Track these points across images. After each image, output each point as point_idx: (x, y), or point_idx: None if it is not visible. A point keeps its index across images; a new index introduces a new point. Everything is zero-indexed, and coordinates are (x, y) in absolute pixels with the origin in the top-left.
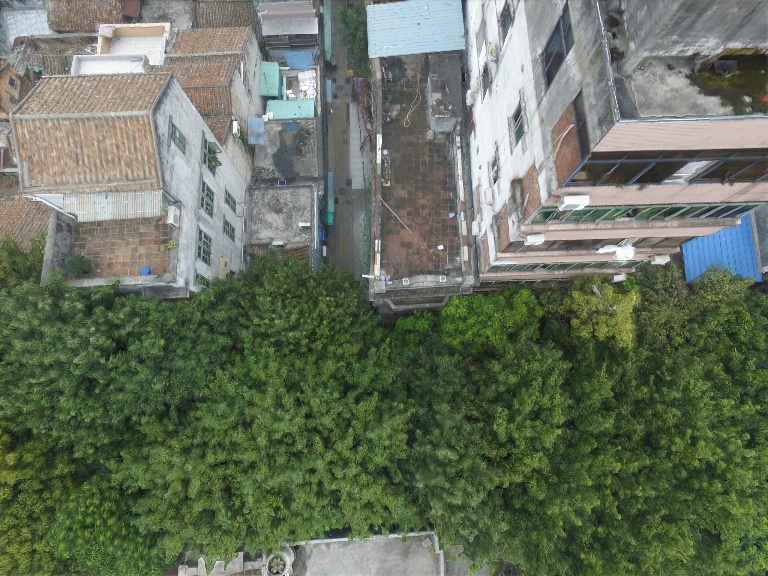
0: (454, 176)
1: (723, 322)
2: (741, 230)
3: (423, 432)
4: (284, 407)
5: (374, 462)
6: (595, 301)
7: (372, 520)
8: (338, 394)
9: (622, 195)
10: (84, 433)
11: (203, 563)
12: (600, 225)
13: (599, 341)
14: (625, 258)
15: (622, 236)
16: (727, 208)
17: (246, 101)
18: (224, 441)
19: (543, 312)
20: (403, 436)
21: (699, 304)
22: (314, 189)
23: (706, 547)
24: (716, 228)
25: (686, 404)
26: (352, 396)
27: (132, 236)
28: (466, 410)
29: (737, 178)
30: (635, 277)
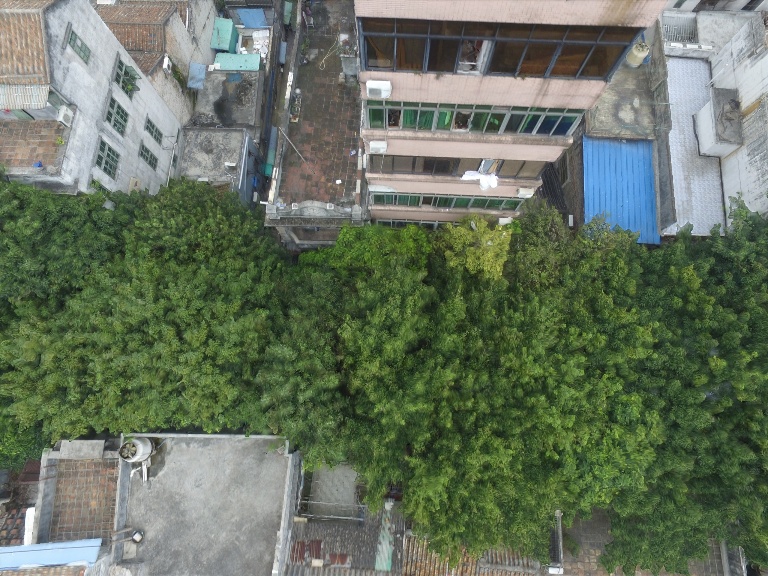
0: (360, 117)
1: (598, 268)
2: (645, 194)
3: (277, 334)
4: (143, 296)
5: (220, 353)
6: (465, 232)
7: (214, 408)
8: (199, 291)
9: (428, 87)
10: None
11: (65, 447)
12: (437, 134)
13: (473, 275)
14: (489, 187)
15: (471, 155)
16: (550, 120)
17: (189, 47)
18: (85, 323)
19: (430, 249)
20: (252, 333)
21: (577, 249)
22: (245, 133)
23: (545, 472)
24: (556, 150)
25: (532, 328)
26: (218, 299)
27: (33, 137)
28: (325, 321)
29: (530, 74)
30: (520, 221)
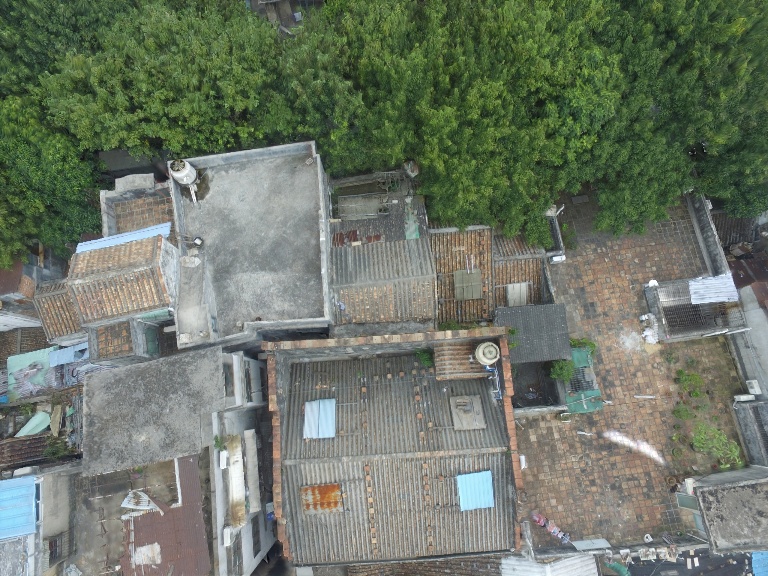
0: None
1: None
2: None
3: None
4: None
5: (245, 54)
6: None
7: (247, 102)
8: (216, 17)
9: None
10: (6, 62)
11: (120, 183)
12: None
13: (448, 3)
14: None
15: None
16: None
17: None
18: (122, 52)
19: None
20: None
21: None
22: None
23: None
24: None
25: None
26: None
27: None
28: None
29: None
30: None
